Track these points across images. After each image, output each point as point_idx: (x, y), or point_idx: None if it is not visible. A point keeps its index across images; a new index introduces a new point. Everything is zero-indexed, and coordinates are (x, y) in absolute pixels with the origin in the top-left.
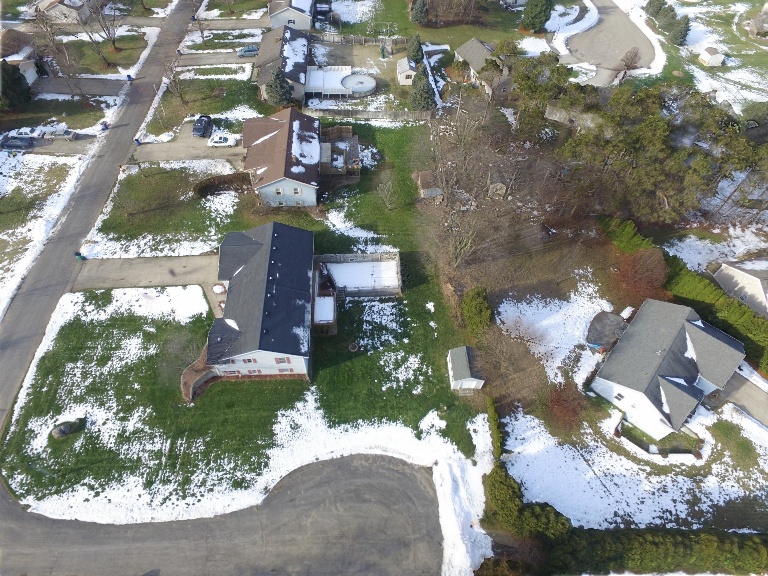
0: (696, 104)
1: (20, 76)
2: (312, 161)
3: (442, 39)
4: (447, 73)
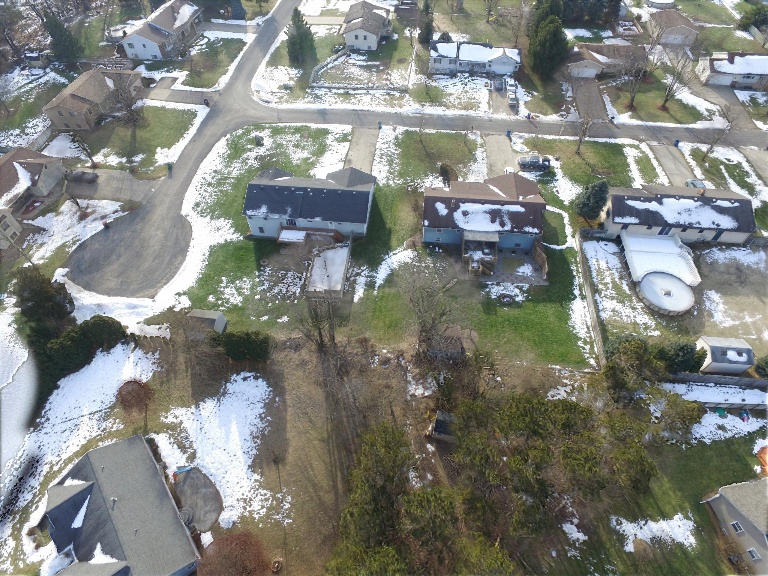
0: None
1: (557, 59)
2: (461, 222)
3: None
4: None
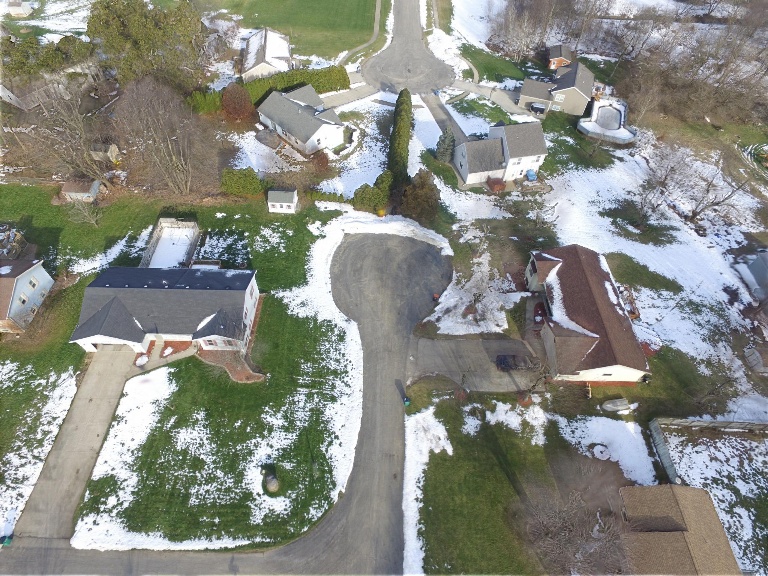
0: (124, 7)
1: None
2: None
3: None
4: None
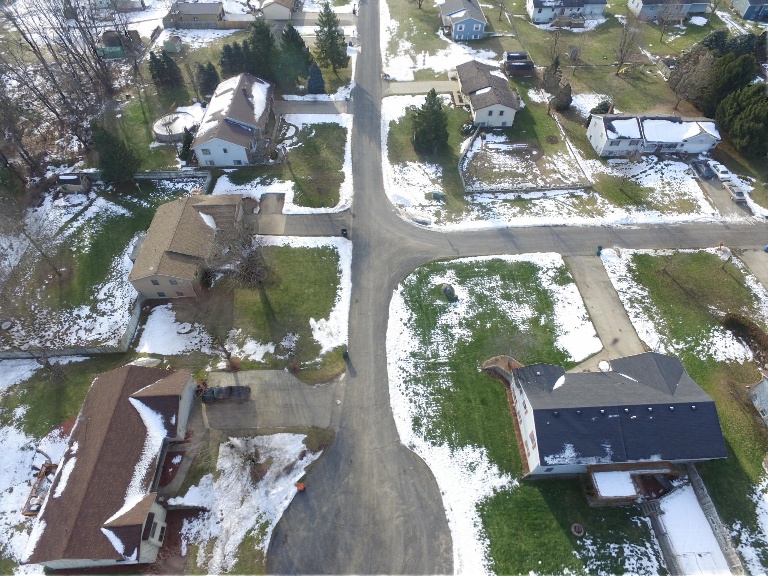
0: None
1: None
2: None
3: None
4: None
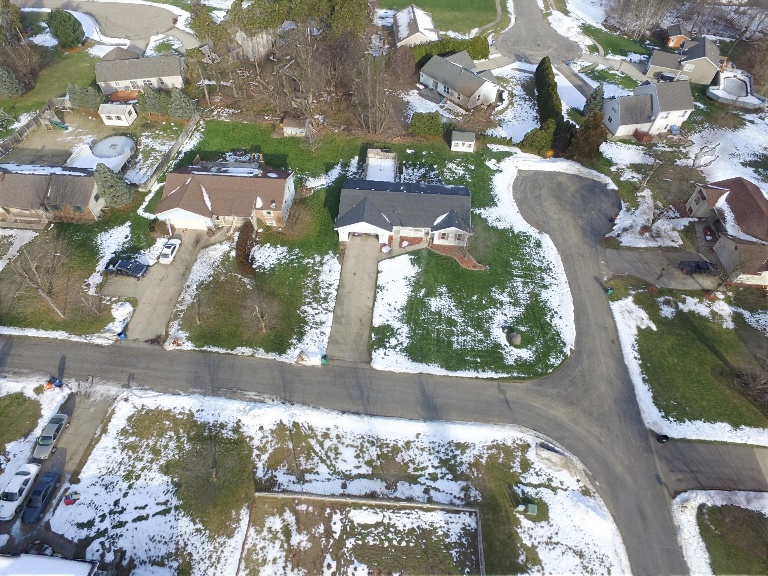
0: None
1: None
2: None
3: (56, 90)
4: (121, 100)
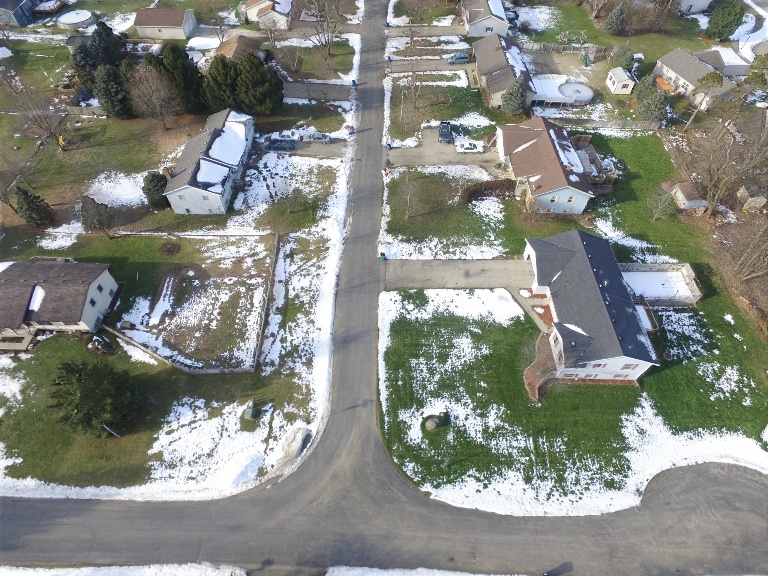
0: None
1: (280, 81)
2: (579, 170)
3: (635, 48)
4: None
